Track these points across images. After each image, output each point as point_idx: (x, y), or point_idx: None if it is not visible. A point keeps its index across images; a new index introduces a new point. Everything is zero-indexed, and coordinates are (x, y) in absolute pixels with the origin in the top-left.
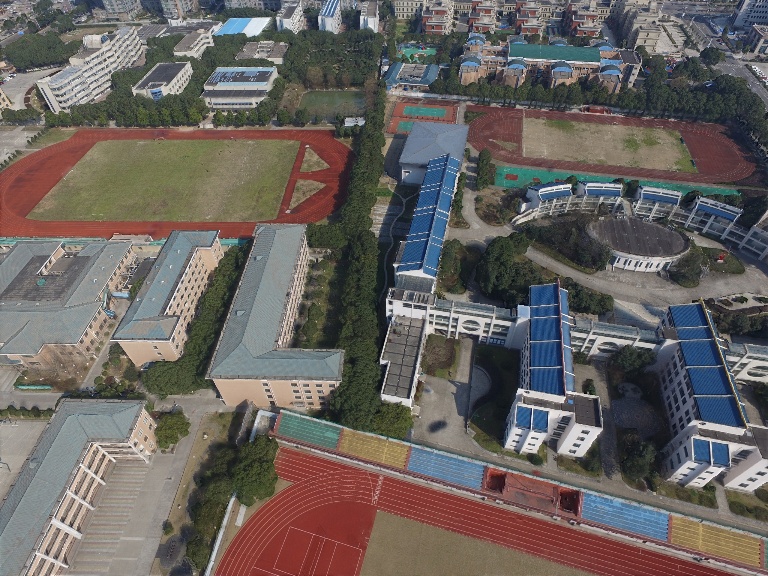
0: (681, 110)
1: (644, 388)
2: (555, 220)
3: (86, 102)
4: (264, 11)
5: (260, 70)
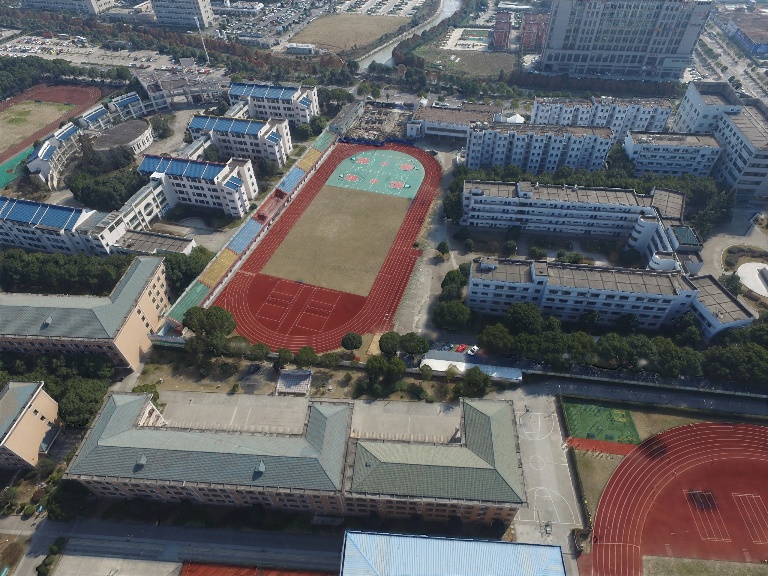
0: (6, 89)
1: None
2: (69, 170)
3: None
4: None
5: None
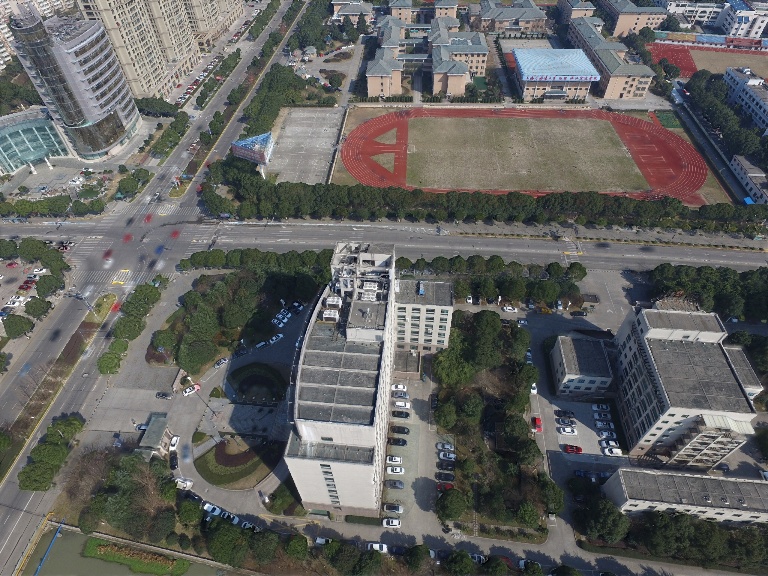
0: None
1: None
2: None
3: None
4: None
5: None
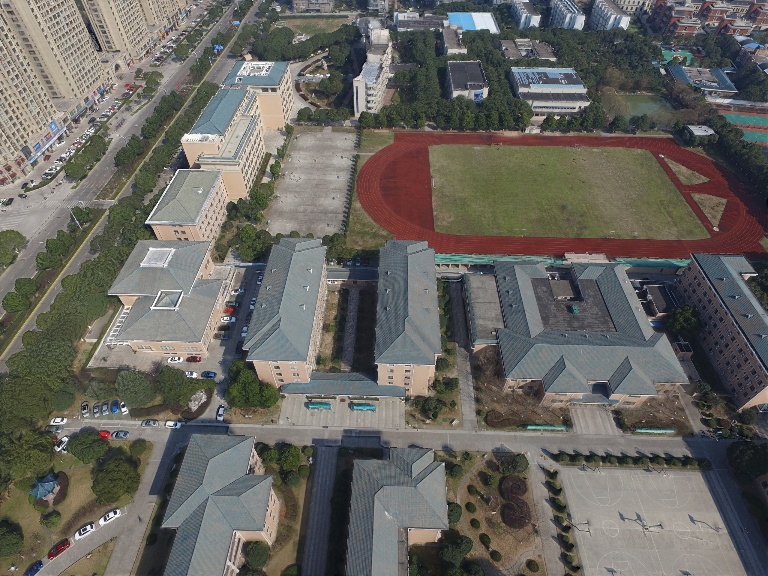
0: None
1: None
2: None
3: (380, 101)
4: (482, 6)
5: (560, 71)
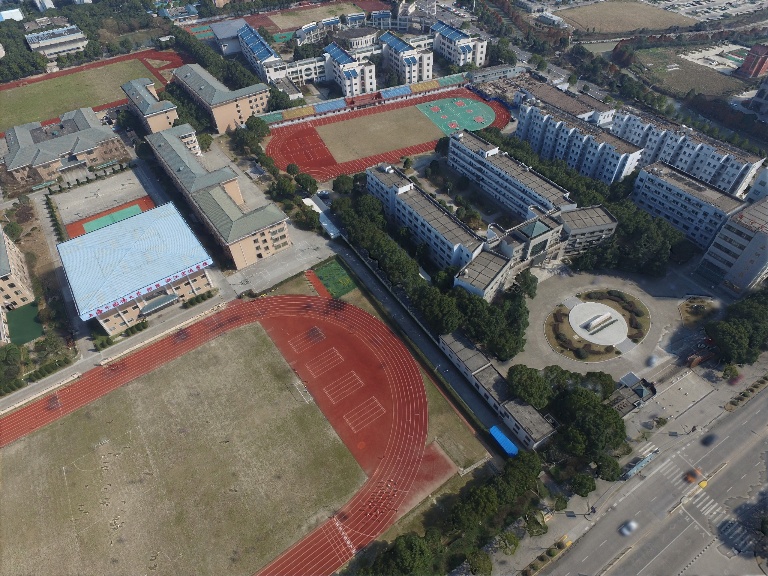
0: None
1: (386, 71)
2: None
3: None
4: (8, 5)
5: (65, 29)
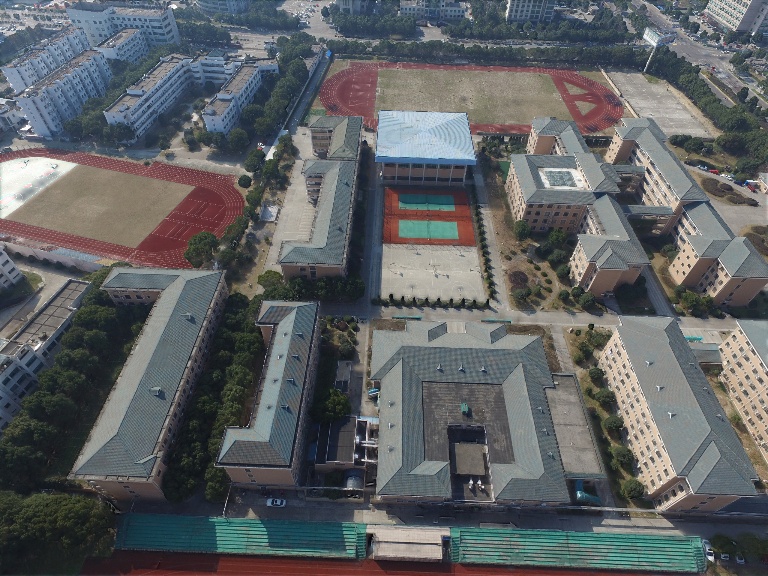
0: None
1: None
2: None
3: None
4: None
5: None
